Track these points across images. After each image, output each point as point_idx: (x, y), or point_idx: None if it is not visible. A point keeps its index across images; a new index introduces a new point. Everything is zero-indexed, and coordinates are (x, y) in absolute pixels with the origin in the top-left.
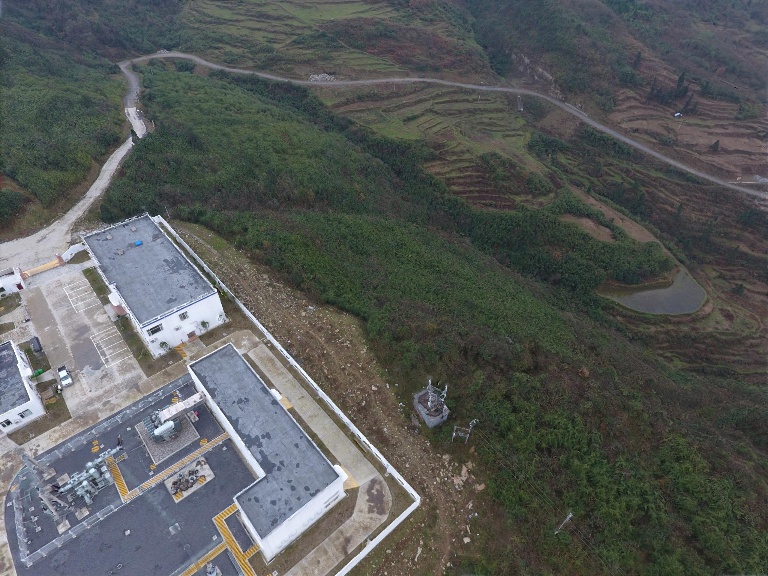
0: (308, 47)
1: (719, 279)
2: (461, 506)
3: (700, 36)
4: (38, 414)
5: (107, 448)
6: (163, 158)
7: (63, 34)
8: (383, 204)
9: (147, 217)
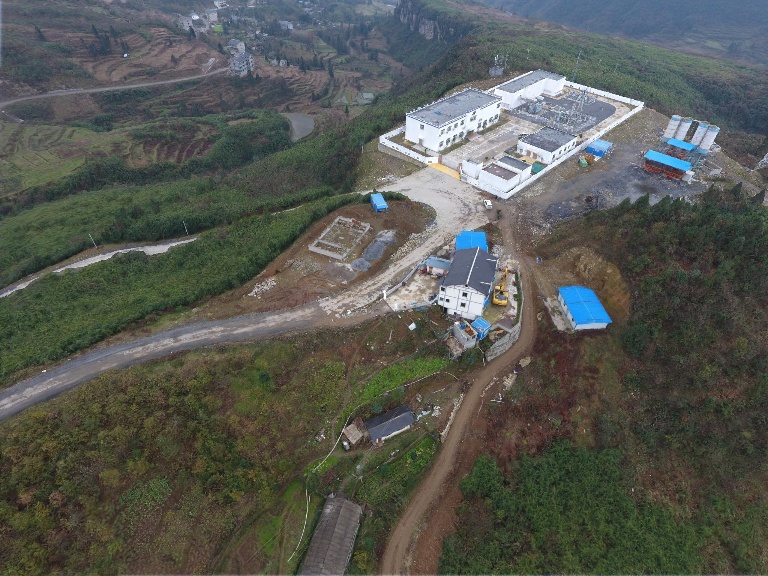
0: None
1: None
2: None
3: None
4: None
5: None
6: None
7: None
8: None
9: None
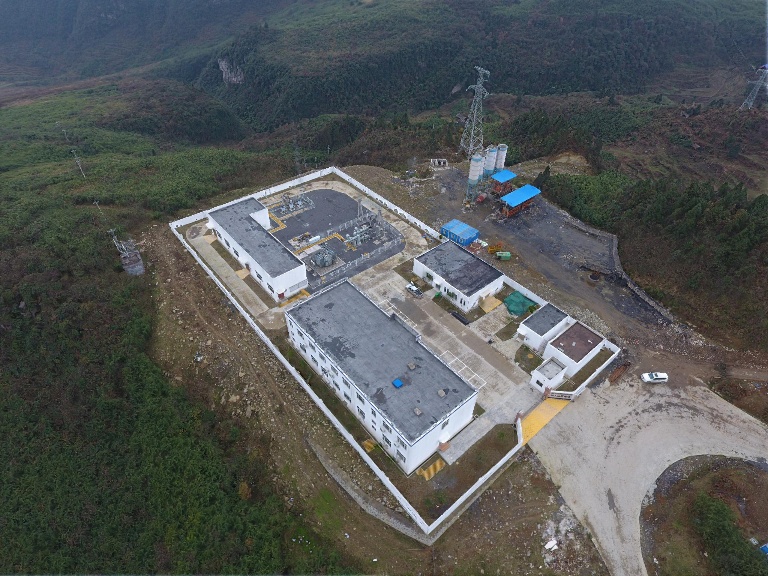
0: None
1: None
2: None
3: None
4: None
5: (359, 254)
6: None
7: None
8: None
9: None
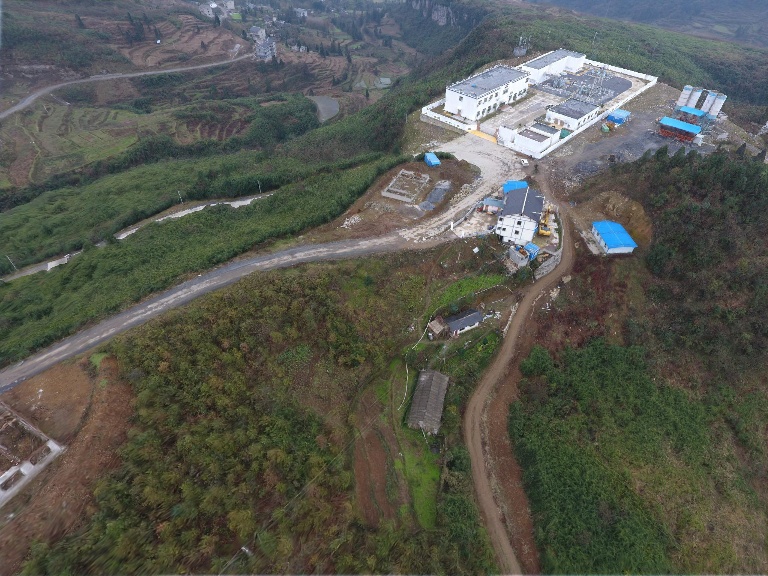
0: None
1: None
2: None
3: None
4: None
5: None
6: None
7: None
8: None
9: None
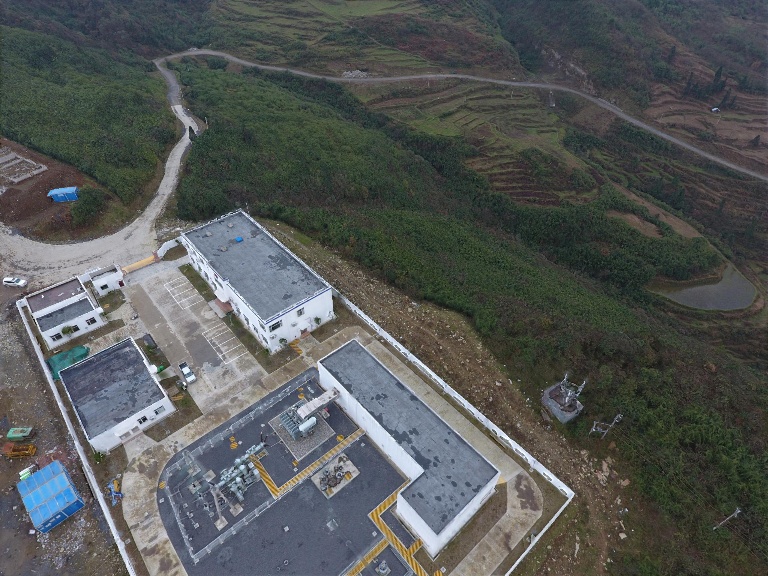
0: (340, 44)
1: (763, 275)
2: (610, 502)
3: (732, 30)
4: (169, 411)
5: (245, 444)
6: (223, 155)
7: (96, 32)
8: (431, 201)
9: (240, 213)
